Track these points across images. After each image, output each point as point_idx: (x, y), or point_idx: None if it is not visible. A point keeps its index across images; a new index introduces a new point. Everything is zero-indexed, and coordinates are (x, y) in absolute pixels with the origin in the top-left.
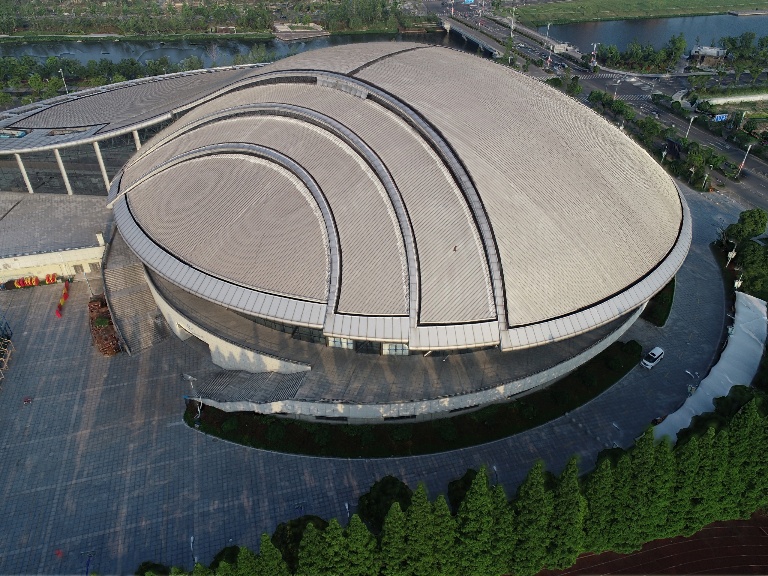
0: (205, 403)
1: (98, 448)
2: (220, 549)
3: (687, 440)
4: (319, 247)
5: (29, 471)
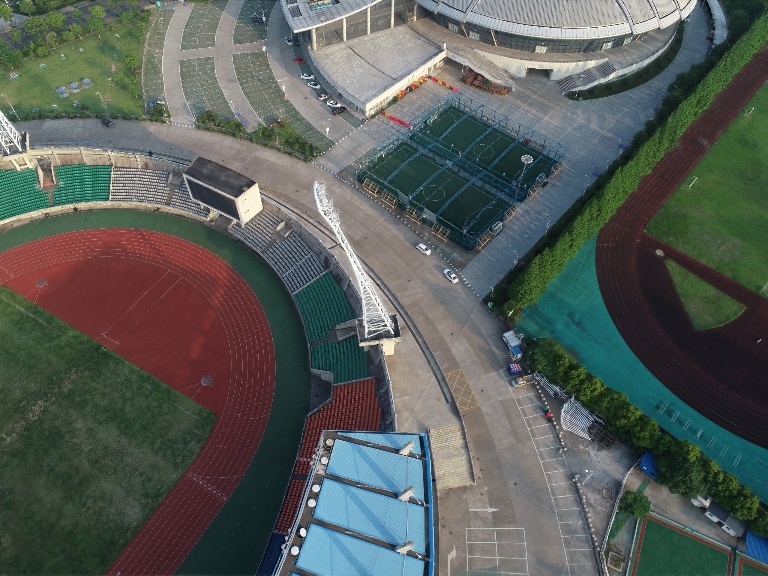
0: (575, 90)
1: (559, 120)
2: (638, 122)
3: (736, 32)
4: (610, 0)
5: (549, 135)
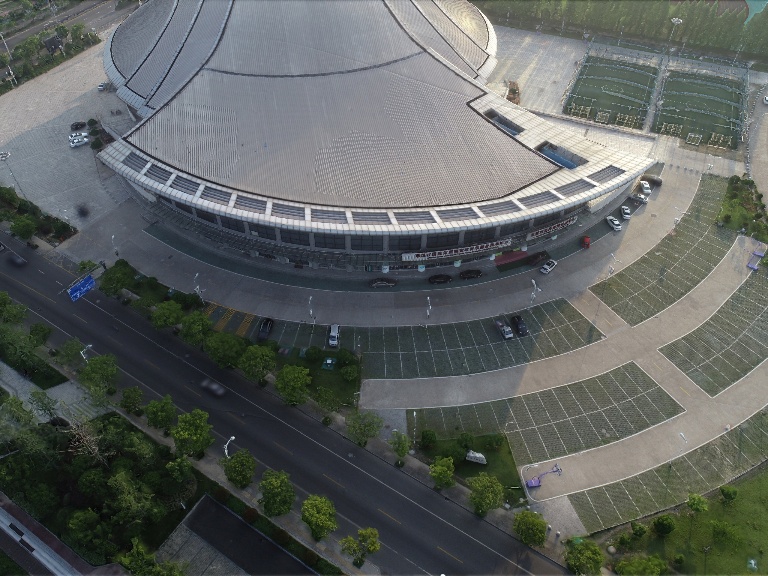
0: None
1: None
2: None
3: None
4: None
5: None
